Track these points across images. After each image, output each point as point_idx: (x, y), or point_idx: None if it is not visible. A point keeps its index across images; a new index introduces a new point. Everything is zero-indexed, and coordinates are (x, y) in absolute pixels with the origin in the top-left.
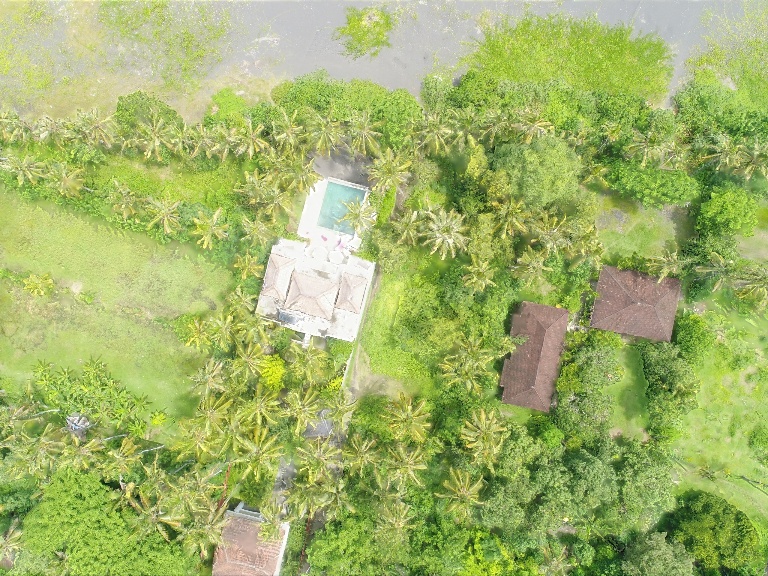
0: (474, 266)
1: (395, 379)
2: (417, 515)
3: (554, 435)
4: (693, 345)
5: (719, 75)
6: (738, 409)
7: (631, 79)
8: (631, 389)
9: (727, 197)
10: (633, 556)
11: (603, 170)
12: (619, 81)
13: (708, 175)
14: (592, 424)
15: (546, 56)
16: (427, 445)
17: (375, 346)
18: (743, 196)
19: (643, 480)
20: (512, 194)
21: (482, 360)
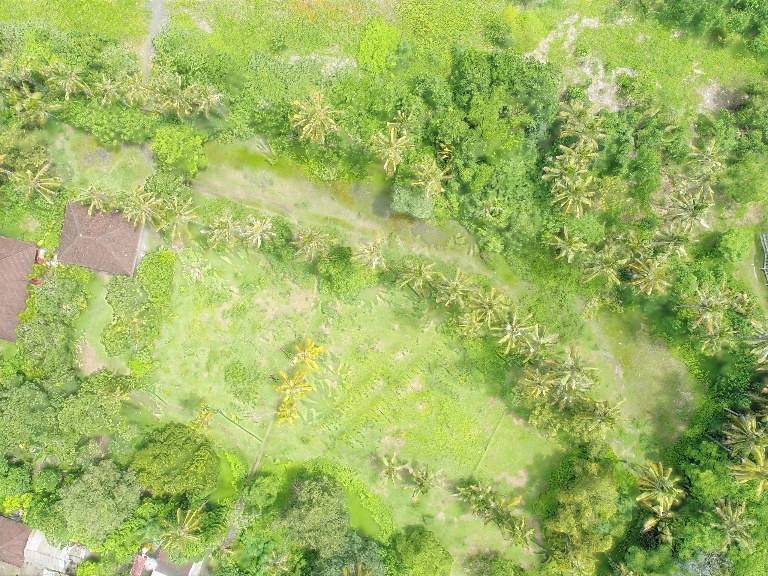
0: None
1: None
2: None
3: (11, 364)
4: None
5: (195, 18)
6: (215, 344)
7: (111, 21)
8: None
9: (163, 133)
10: None
11: (55, 106)
12: (99, 23)
13: None
14: None
15: None
16: None
17: None
18: (179, 132)
19: (77, 406)
20: None
21: None
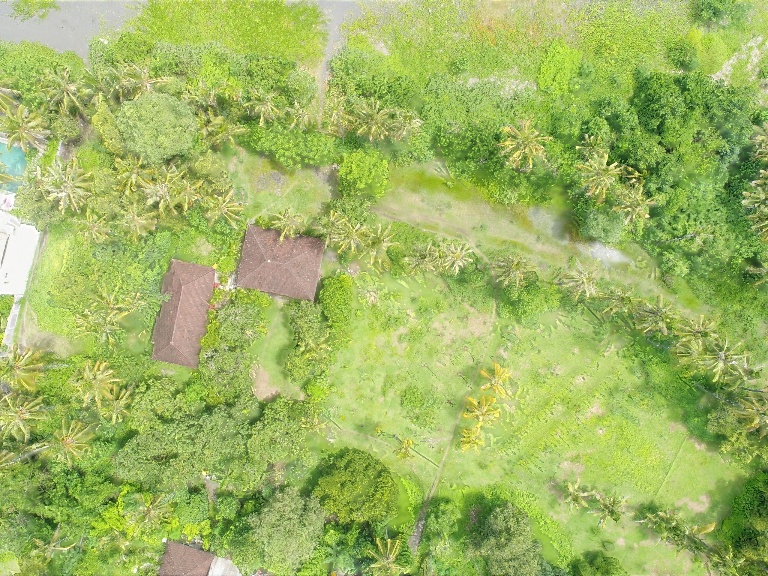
0: (87, 220)
1: (62, 336)
2: (71, 469)
3: (194, 390)
4: (328, 303)
5: (372, 40)
6: (391, 369)
7: (287, 43)
8: (288, 348)
9: (353, 157)
10: (262, 509)
11: (240, 130)
12: (275, 45)
13: (357, 138)
14: (225, 379)
15: (205, 20)
16: (72, 399)
17: (40, 304)
18: (369, 157)
19: (267, 434)
20: (128, 150)
21: (115, 315)
